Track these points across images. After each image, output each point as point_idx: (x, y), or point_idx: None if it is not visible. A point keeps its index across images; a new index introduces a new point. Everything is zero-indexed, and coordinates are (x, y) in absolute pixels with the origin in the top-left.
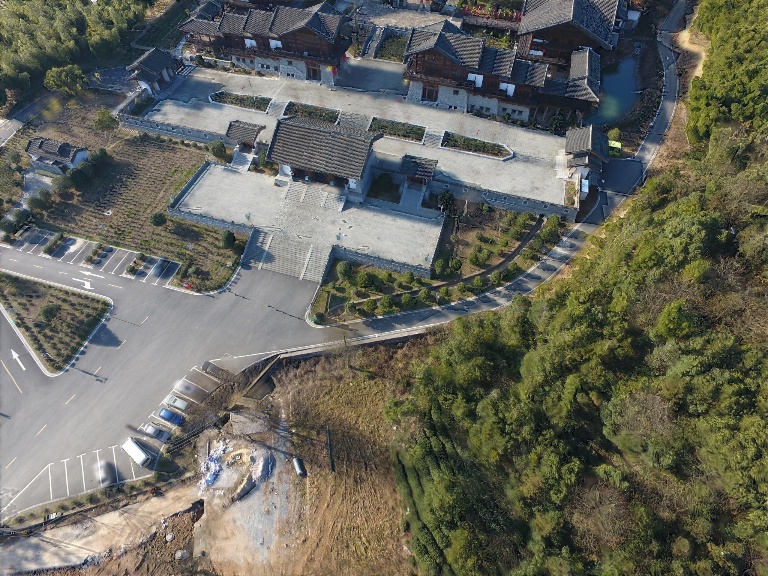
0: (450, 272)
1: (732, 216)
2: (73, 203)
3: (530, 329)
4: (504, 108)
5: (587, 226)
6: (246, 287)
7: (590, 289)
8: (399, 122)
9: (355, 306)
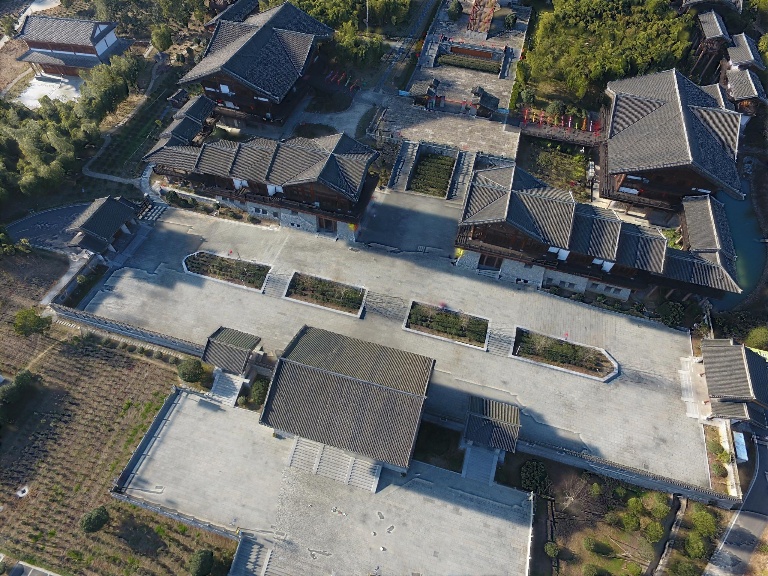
0: None
1: None
2: None
3: None
4: (594, 283)
5: (750, 518)
6: None
7: None
8: (450, 310)
9: None
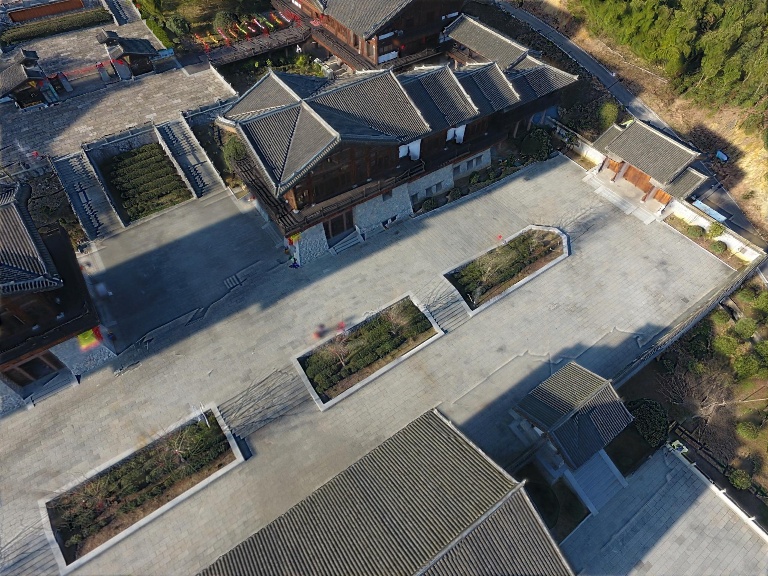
0: None
1: None
2: None
3: None
4: (455, 167)
5: (767, 266)
6: None
7: None
8: (354, 326)
9: None
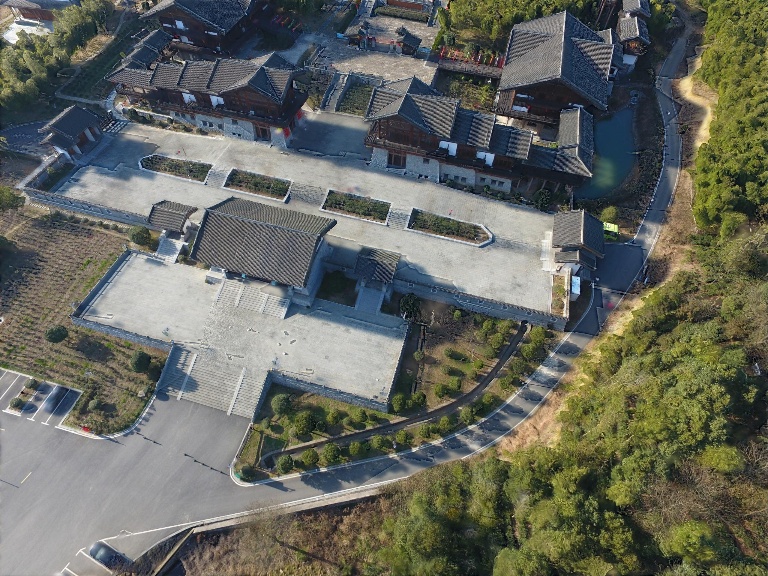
0: (412, 405)
1: (756, 348)
2: None
3: (507, 500)
4: (482, 178)
5: (578, 336)
6: (159, 426)
7: (582, 471)
8: (359, 196)
9: (290, 462)
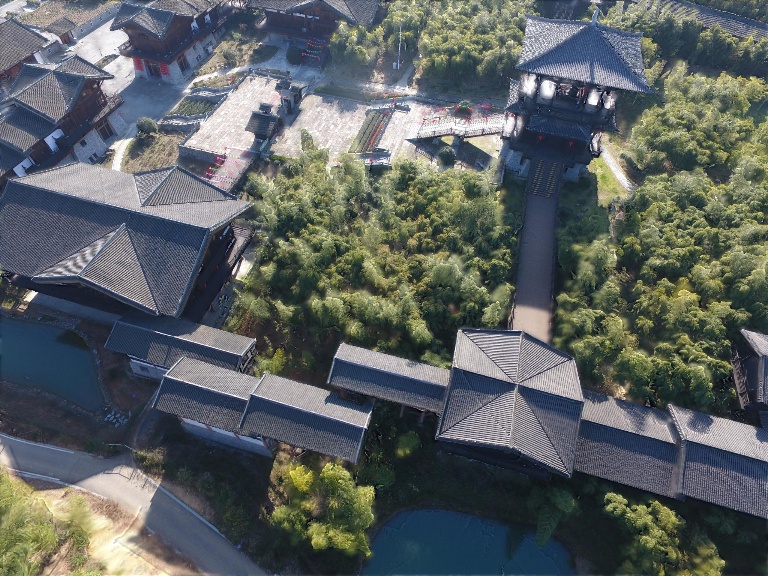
0: None
1: None
2: (64, 1)
3: None
4: None
5: None
6: None
7: None
8: None
9: None
